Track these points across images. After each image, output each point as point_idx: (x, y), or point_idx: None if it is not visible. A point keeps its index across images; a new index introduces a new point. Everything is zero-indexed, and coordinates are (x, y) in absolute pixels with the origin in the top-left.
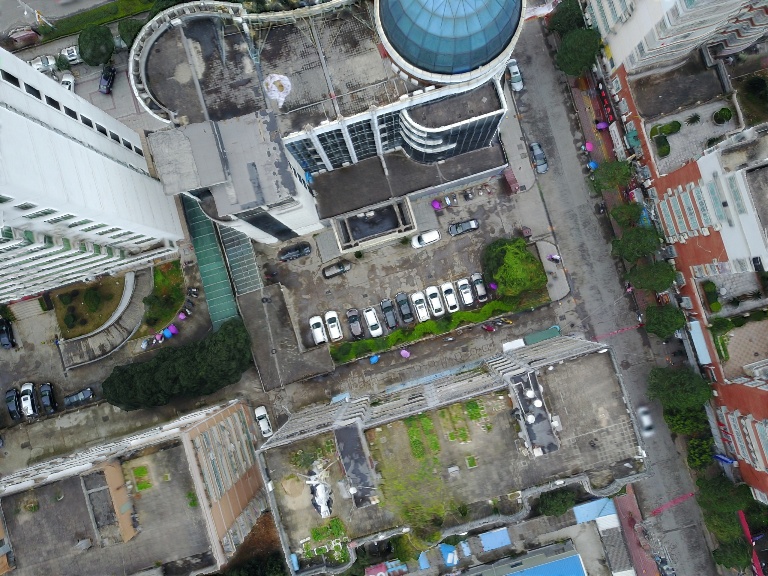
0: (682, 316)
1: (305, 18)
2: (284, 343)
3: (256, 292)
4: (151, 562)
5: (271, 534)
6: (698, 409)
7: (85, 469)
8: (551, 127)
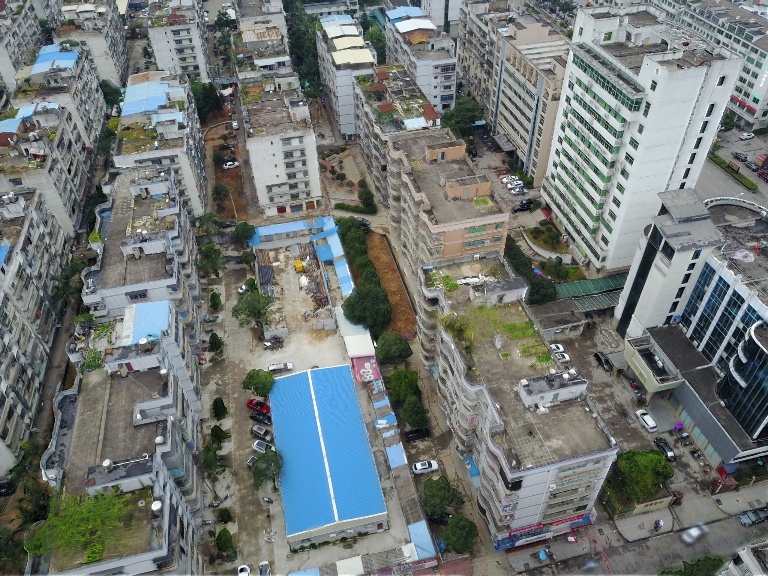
0: None
1: None
2: (543, 322)
3: (577, 308)
4: (433, 205)
5: (400, 322)
6: None
7: None
8: None
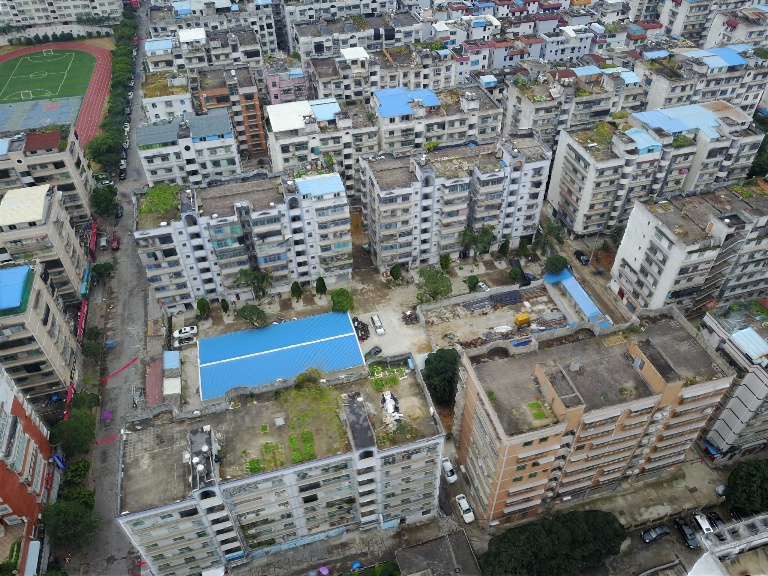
0: None
1: None
2: None
3: None
4: (519, 358)
5: (452, 420)
6: None
7: (589, 418)
8: None
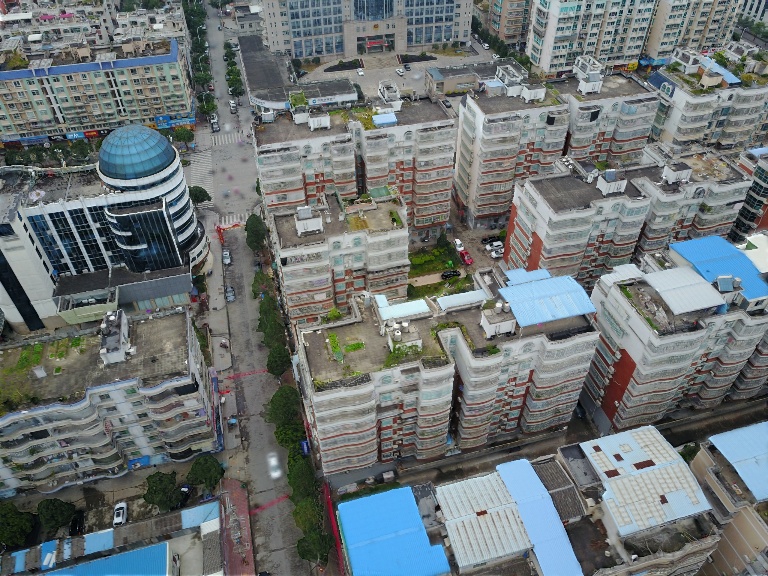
0: (286, 351)
1: (68, 173)
2: None
3: None
4: None
5: None
6: (299, 423)
7: None
8: (244, 281)
